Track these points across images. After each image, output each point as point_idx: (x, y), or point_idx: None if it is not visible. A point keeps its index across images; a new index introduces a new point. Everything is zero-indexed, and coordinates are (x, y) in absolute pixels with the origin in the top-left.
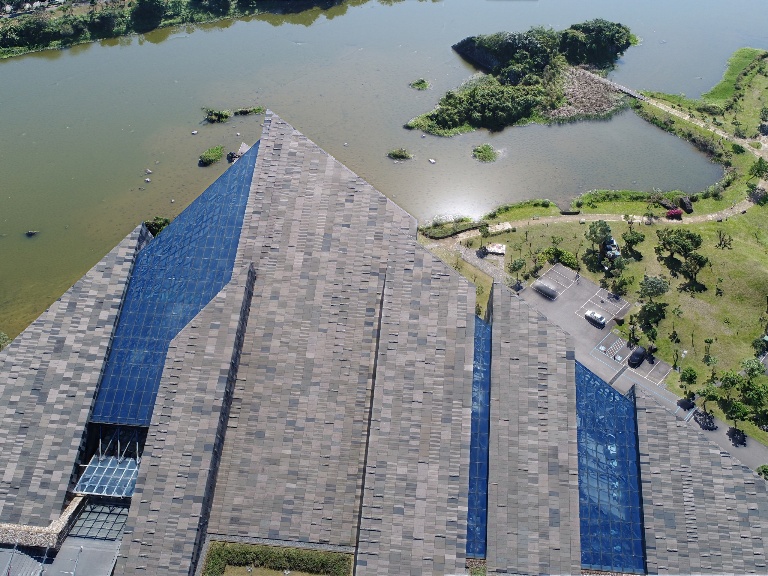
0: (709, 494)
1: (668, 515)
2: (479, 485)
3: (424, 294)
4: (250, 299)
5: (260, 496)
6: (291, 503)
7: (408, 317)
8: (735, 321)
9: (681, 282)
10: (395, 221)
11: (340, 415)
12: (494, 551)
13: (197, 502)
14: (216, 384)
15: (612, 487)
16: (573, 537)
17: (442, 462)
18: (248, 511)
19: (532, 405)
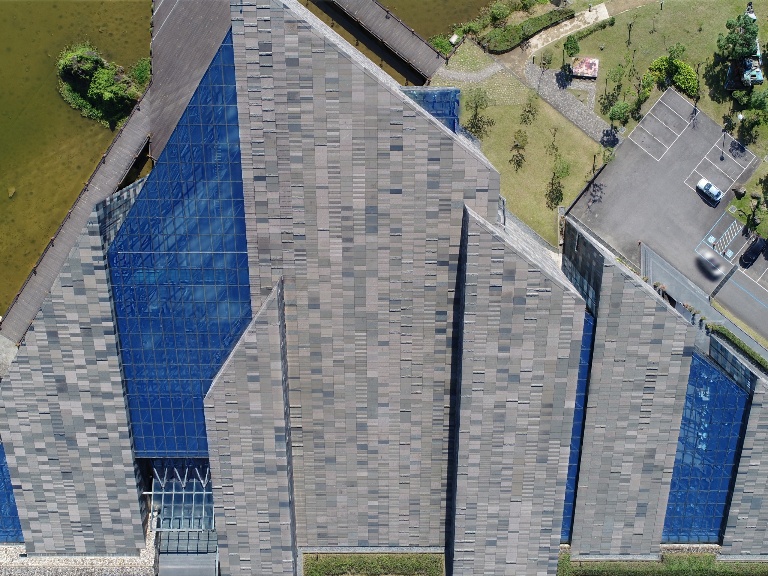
0: None
1: (756, 500)
2: None
3: (517, 319)
4: (283, 314)
5: (343, 514)
6: (376, 518)
7: (496, 350)
8: None
9: None
10: (467, 179)
11: (416, 435)
12: (579, 540)
13: (286, 551)
14: (274, 443)
15: None
16: (657, 524)
17: (536, 500)
18: (334, 527)
19: (634, 410)
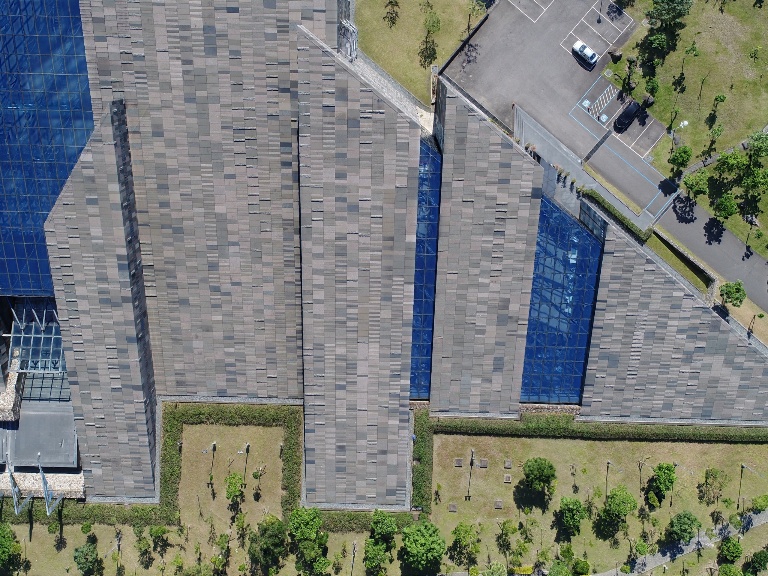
0: (660, 336)
1: (613, 357)
2: (425, 322)
3: (352, 143)
4: (126, 140)
5: (200, 361)
6: (233, 365)
7: (333, 177)
8: (765, 55)
9: None
10: None
11: (268, 277)
12: (437, 396)
13: (137, 390)
14: (117, 273)
15: (565, 301)
16: (515, 380)
17: (383, 341)
18: (191, 375)
19: (485, 255)
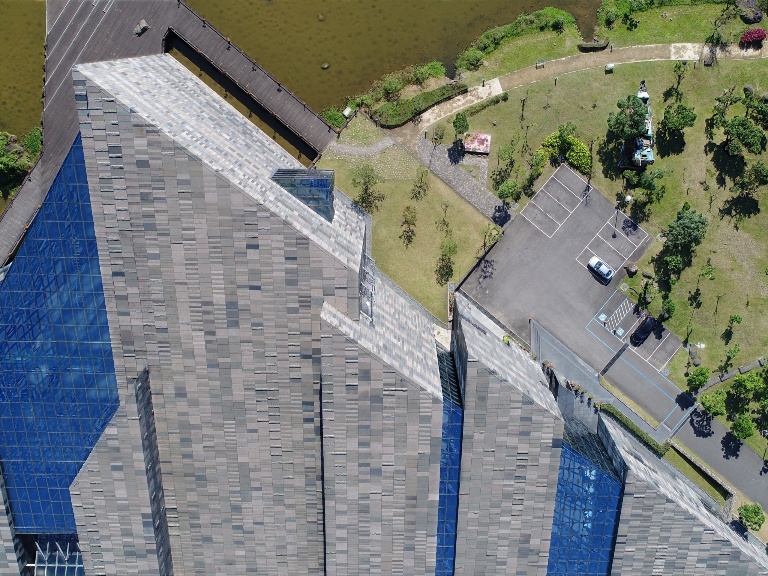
0: (680, 565)
1: None
2: None
3: (375, 416)
4: (149, 402)
5: None
6: None
7: (356, 445)
8: None
9: (727, 197)
10: (325, 277)
11: (291, 518)
12: None
13: None
14: (142, 529)
15: (584, 515)
16: None
17: None
18: None
19: (506, 497)
